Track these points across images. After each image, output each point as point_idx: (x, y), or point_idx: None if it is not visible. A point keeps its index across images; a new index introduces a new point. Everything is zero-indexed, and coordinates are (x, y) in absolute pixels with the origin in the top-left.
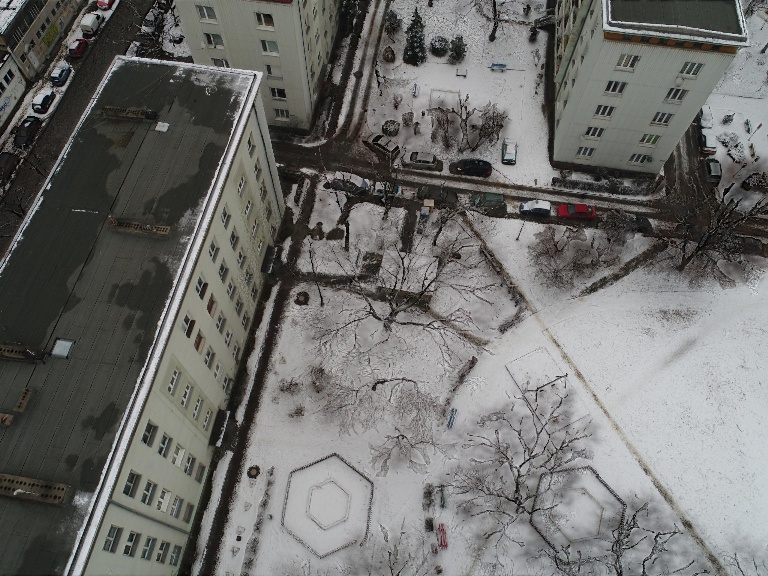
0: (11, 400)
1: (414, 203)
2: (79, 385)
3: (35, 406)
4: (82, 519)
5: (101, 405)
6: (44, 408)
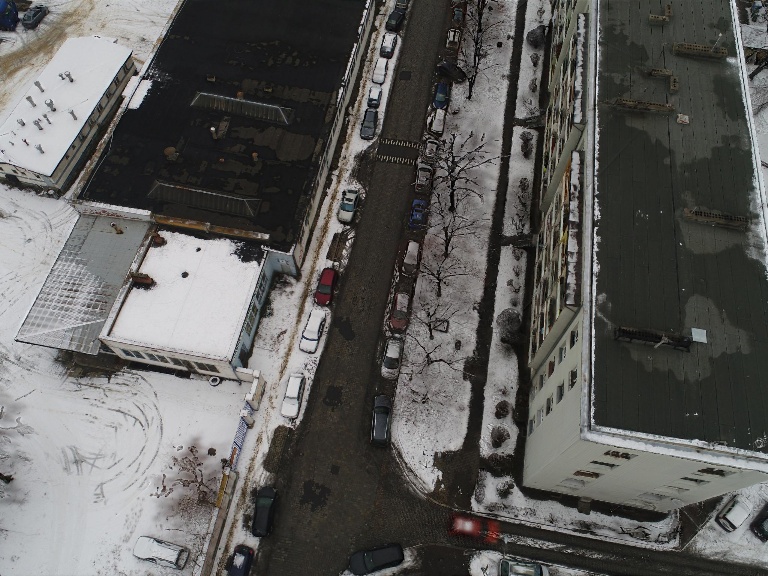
0: (655, 14)
1: (741, 3)
2: (694, 8)
3: (674, 16)
4: (738, 69)
5: (715, 18)
6: (680, 18)
